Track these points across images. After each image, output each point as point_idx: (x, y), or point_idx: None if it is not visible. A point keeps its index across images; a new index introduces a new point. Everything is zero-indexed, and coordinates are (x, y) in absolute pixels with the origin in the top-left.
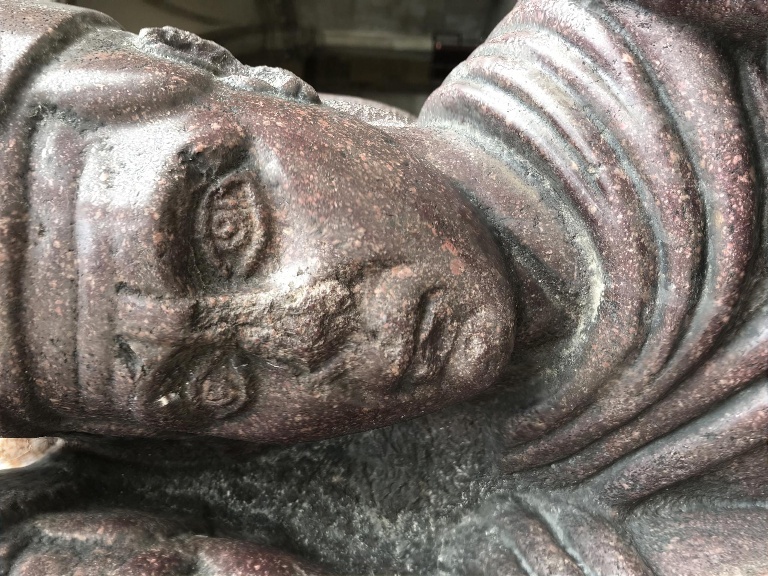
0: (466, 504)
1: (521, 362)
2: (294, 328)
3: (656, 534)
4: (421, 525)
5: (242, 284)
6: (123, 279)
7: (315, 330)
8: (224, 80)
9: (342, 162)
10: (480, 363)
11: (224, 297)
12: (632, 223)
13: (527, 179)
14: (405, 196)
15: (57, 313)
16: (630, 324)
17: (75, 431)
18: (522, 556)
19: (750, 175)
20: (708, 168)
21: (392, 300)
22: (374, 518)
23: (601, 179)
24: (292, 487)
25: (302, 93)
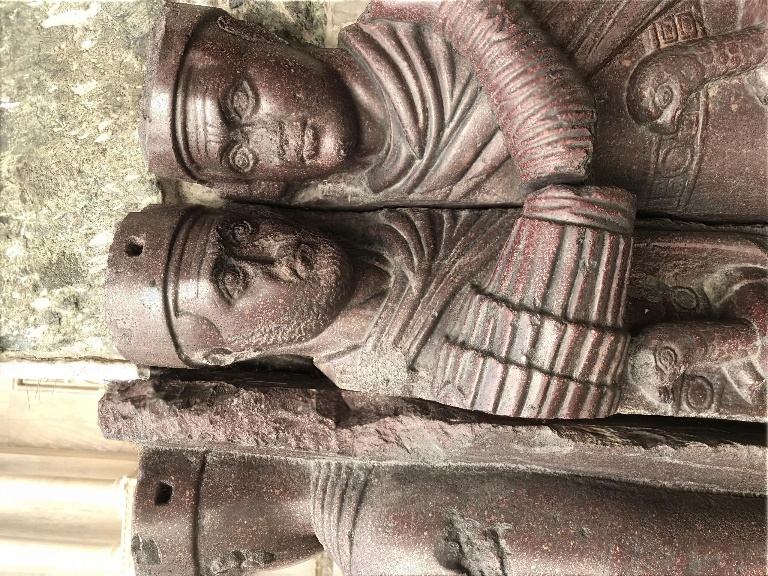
0: None
1: None
2: None
3: None
4: None
5: None
6: None
7: None
8: (244, 566)
9: None
10: None
11: None
12: None
13: None
14: None
15: None
16: None
17: None
18: None
19: None
20: None
21: None
22: None
23: None
24: None
25: None
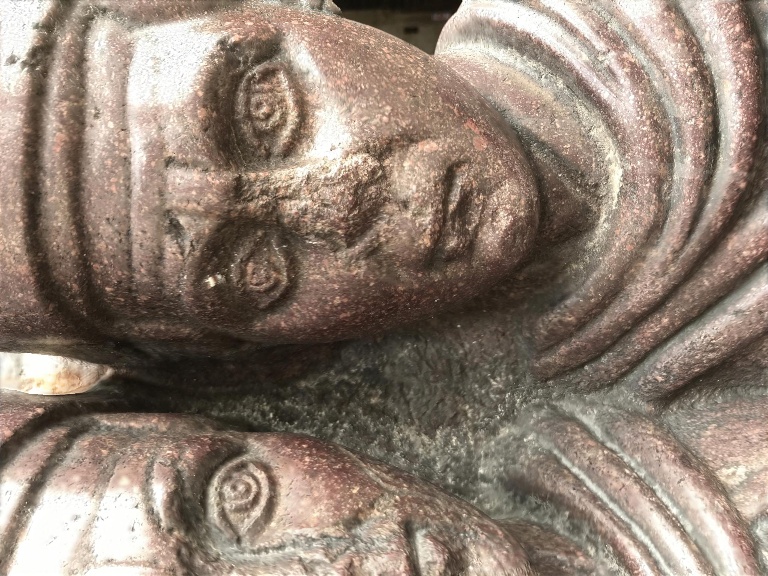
0: (503, 416)
1: (547, 260)
2: (330, 198)
3: (693, 424)
4: (460, 439)
5: (280, 163)
6: (172, 153)
7: (350, 199)
8: None
9: (366, 52)
10: (507, 235)
11: (264, 173)
12: (644, 102)
13: (541, 82)
14: (427, 82)
15: (112, 191)
16: (650, 202)
17: (127, 337)
18: (561, 454)
19: (753, 41)
20: (712, 39)
21: (420, 171)
22: (413, 436)
23: (611, 64)
24: (332, 409)
25: (325, 5)
